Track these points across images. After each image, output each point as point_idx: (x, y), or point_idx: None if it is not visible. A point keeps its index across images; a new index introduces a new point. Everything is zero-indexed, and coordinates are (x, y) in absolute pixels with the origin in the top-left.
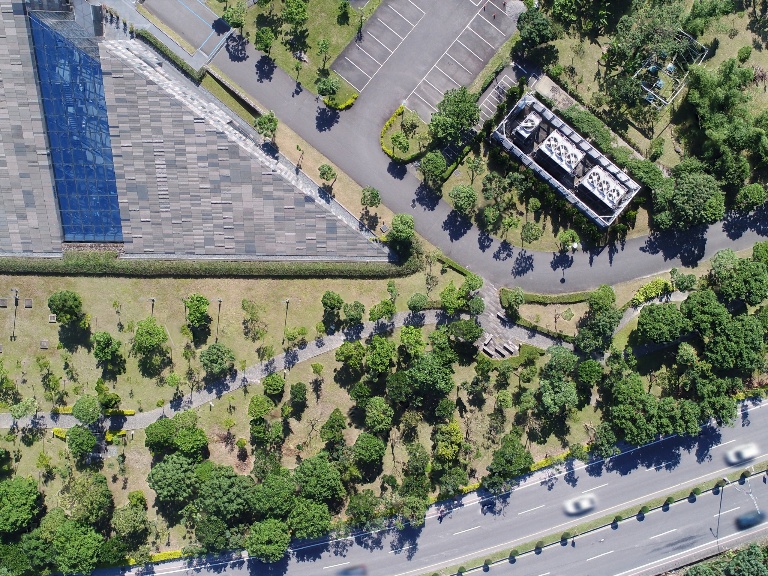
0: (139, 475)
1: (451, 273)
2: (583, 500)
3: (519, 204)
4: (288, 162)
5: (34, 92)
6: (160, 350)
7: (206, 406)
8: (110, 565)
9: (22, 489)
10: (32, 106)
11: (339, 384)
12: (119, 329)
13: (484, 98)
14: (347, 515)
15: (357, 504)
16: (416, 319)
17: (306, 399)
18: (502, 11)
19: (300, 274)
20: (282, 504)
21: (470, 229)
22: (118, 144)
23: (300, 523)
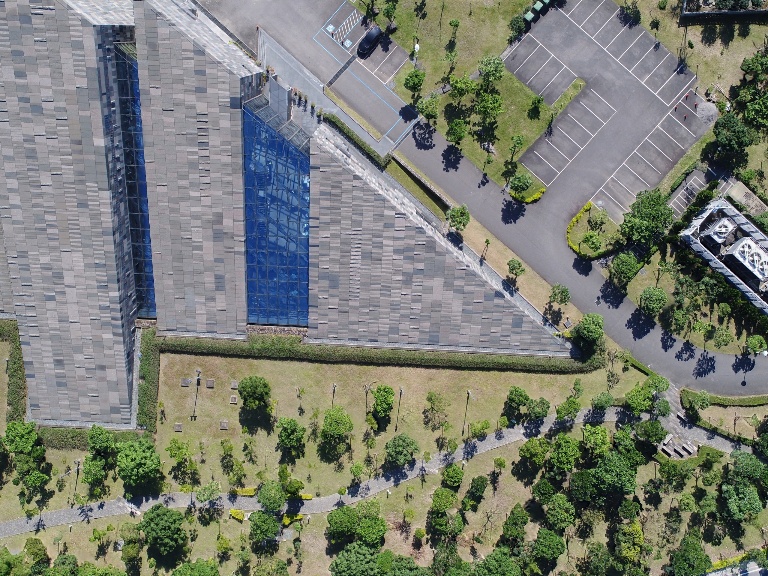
0: (314, 559)
1: (633, 371)
2: None
3: (703, 305)
4: (472, 253)
5: (240, 182)
6: None
7: (383, 493)
8: None
9: (207, 574)
10: (236, 195)
11: (516, 477)
12: (299, 413)
13: (673, 198)
14: None
15: None
16: (596, 416)
17: None
18: (693, 112)
19: (483, 366)
20: None
21: (653, 328)
22: (316, 234)
23: None
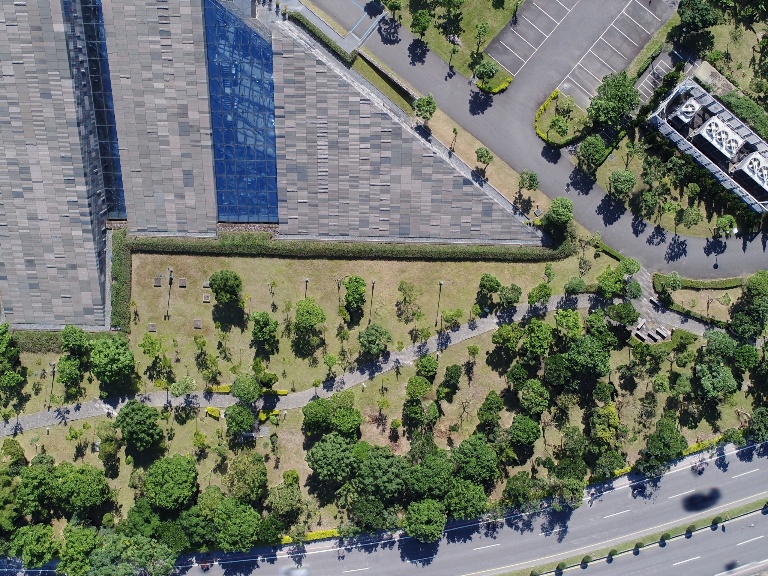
0: (291, 455)
1: (604, 257)
2: (734, 485)
3: (673, 189)
4: (441, 145)
5: (203, 71)
6: (313, 331)
7: (358, 387)
8: (263, 543)
9: (183, 466)
10: (200, 85)
11: (491, 367)
12: (273, 309)
13: (639, 83)
14: (499, 497)
15: (515, 485)
16: (569, 303)
17: (458, 381)
18: None
19: (454, 257)
20: (441, 484)
21: (624, 214)
22: (282, 124)
23: (458, 504)
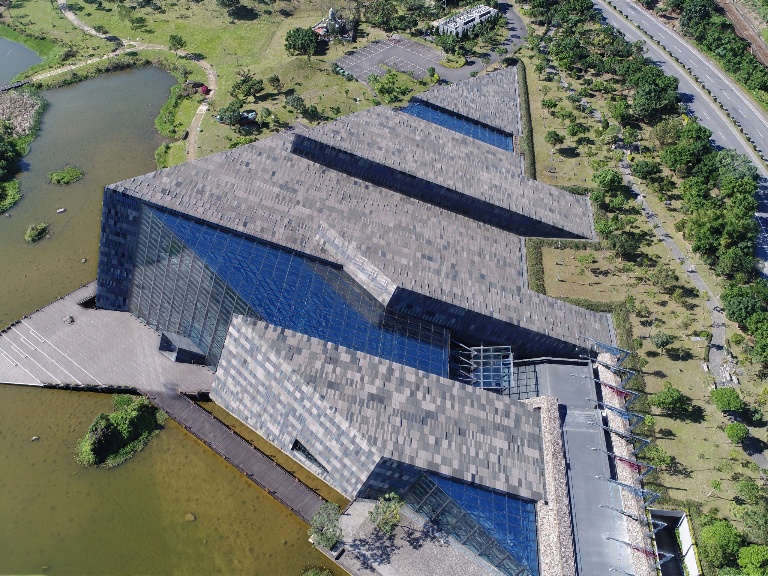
0: None
1: None
2: (622, 26)
3: None
4: None
5: (435, 125)
6: None
7: None
8: None
9: None
10: (442, 129)
11: (581, 79)
12: None
13: None
14: None
15: None
16: None
17: None
18: None
19: None
20: None
21: None
22: None
23: None
